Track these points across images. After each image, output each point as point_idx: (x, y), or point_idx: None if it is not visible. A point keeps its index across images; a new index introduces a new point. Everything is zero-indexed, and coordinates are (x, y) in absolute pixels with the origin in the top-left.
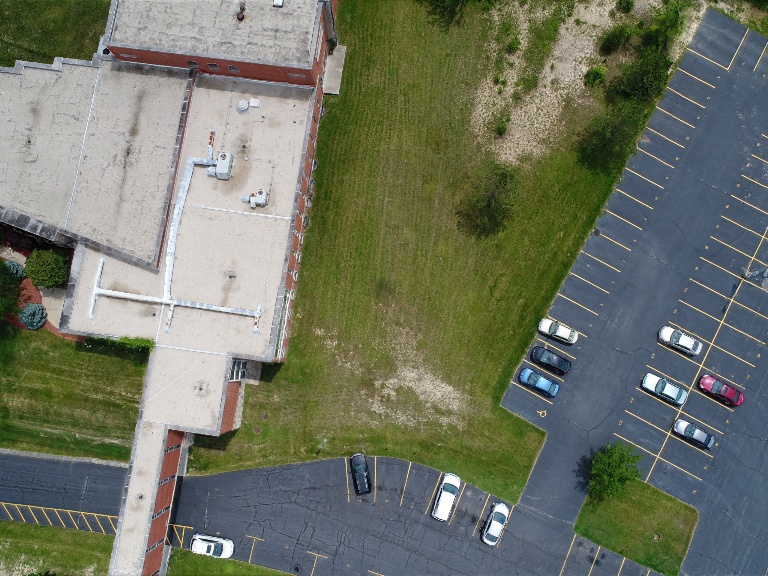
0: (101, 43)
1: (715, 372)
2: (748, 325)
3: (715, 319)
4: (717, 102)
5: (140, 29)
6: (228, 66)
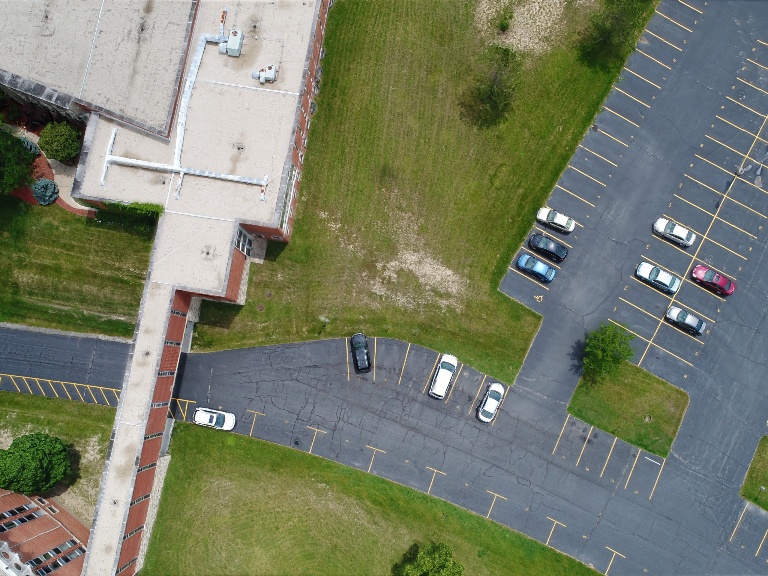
0: None
1: (708, 263)
2: (740, 220)
3: (709, 213)
4: (714, 7)
5: None
6: None
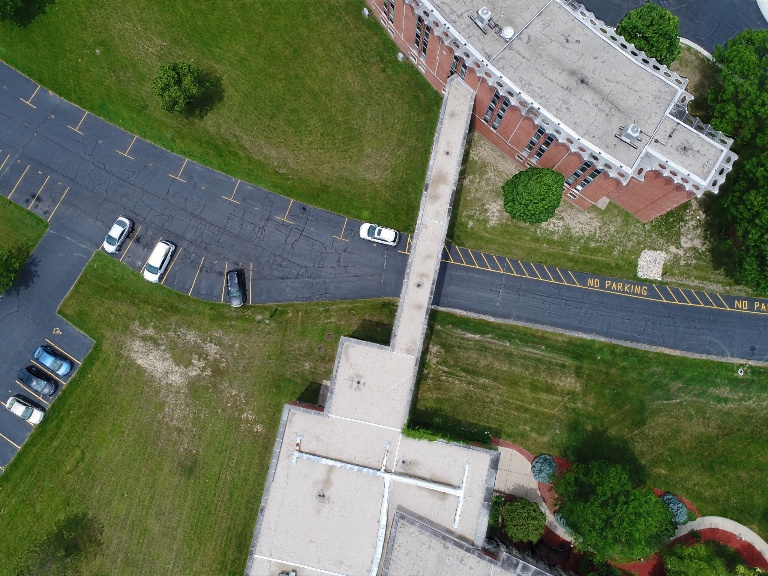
0: None
1: None
2: None
3: None
4: None
5: None
6: None
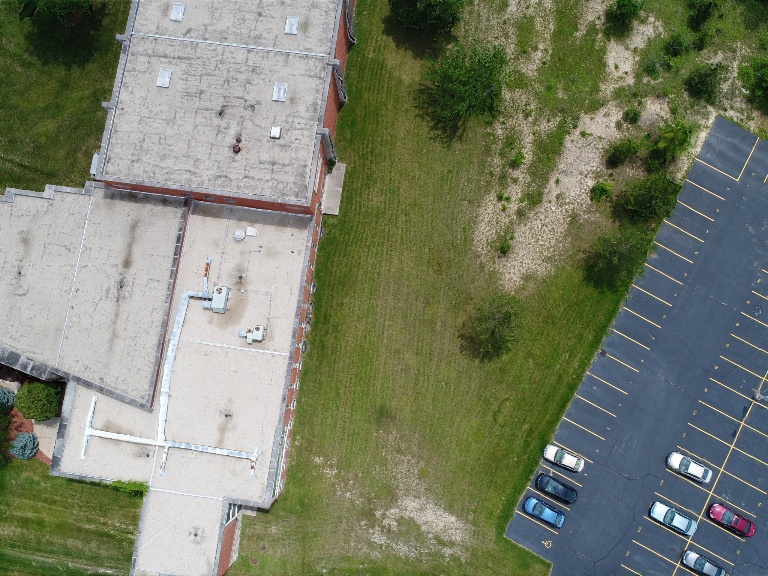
0: (94, 160)
1: (725, 500)
2: (759, 450)
3: (725, 443)
4: (727, 216)
5: (133, 161)
6: (224, 199)
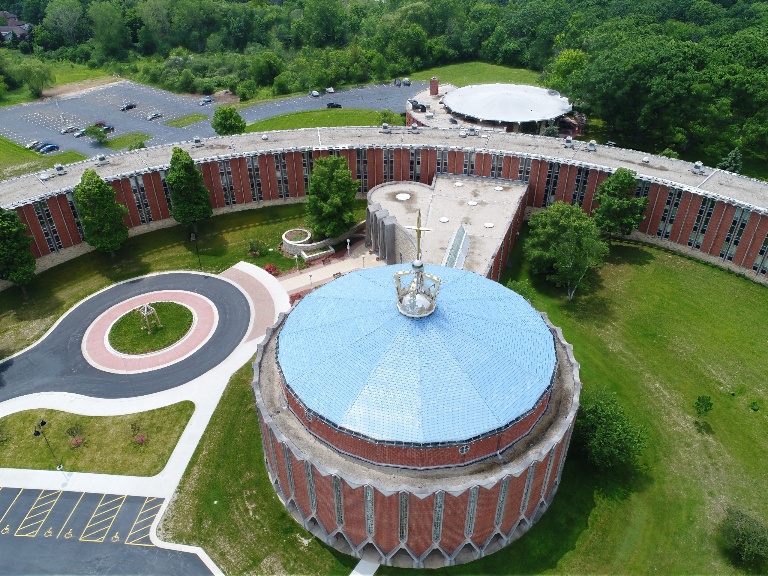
0: None
1: None
2: None
3: None
4: None
5: None
6: None
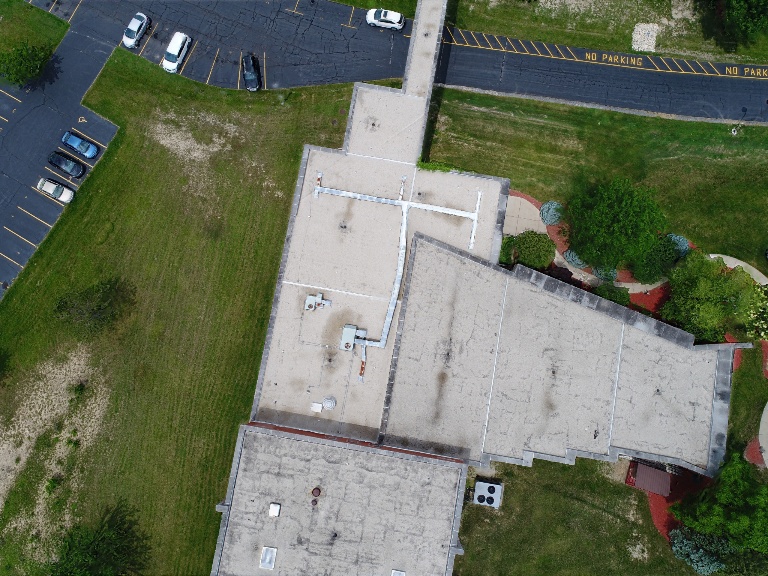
0: (498, 501)
1: None
2: None
3: None
4: None
5: (429, 484)
6: None
